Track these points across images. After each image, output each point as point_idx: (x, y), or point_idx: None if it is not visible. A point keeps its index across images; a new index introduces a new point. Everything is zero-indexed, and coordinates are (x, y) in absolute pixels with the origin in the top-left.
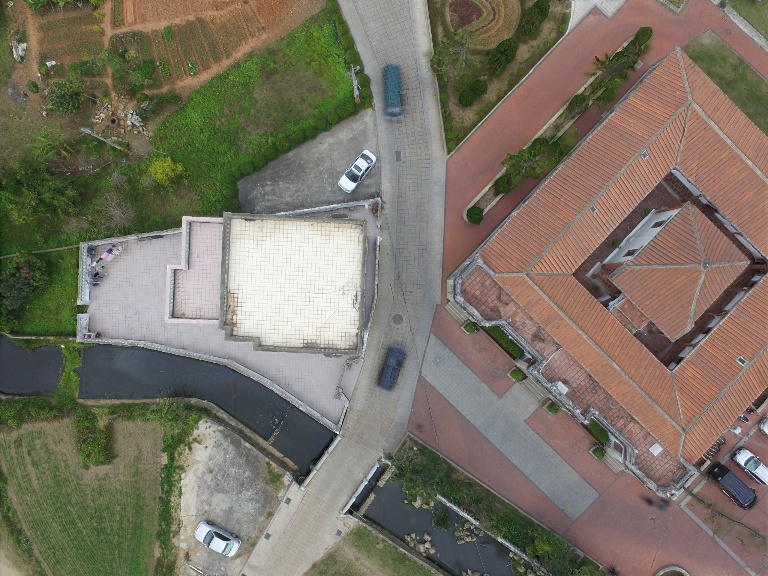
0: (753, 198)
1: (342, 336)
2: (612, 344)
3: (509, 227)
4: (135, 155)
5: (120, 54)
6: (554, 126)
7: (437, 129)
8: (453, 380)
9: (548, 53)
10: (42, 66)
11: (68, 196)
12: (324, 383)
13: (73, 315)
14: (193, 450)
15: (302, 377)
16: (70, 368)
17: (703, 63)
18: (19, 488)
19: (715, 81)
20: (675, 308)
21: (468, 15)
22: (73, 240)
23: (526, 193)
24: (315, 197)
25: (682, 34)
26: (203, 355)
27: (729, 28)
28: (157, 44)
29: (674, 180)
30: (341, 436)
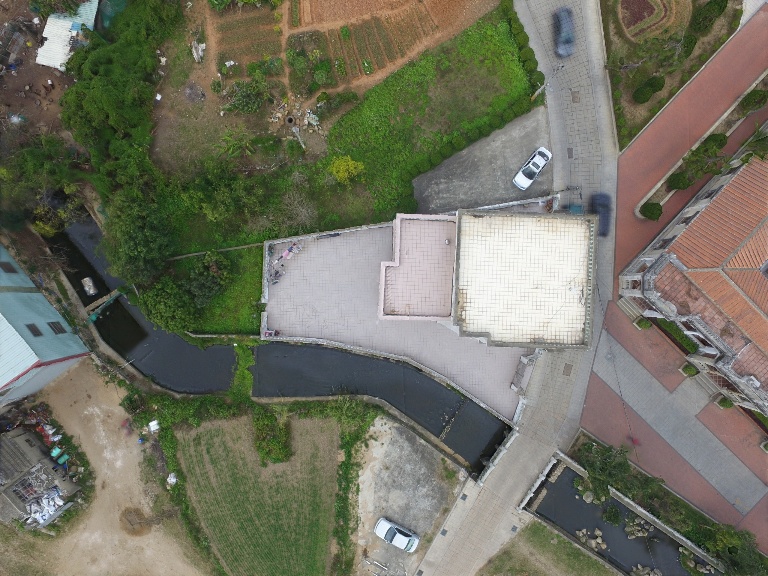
0: None
1: (568, 331)
2: None
3: (698, 222)
4: (311, 154)
5: (298, 54)
6: (726, 122)
7: (608, 126)
8: (625, 376)
9: (719, 50)
10: (221, 66)
11: (256, 195)
12: (498, 379)
13: (252, 313)
14: (370, 447)
15: (476, 374)
16: (244, 366)
17: None
18: (198, 486)
19: None
20: None
21: (640, 12)
22: (252, 239)
23: (697, 189)
24: (488, 194)
25: None
26: (382, 352)
27: None
28: (333, 43)
29: None
30: None
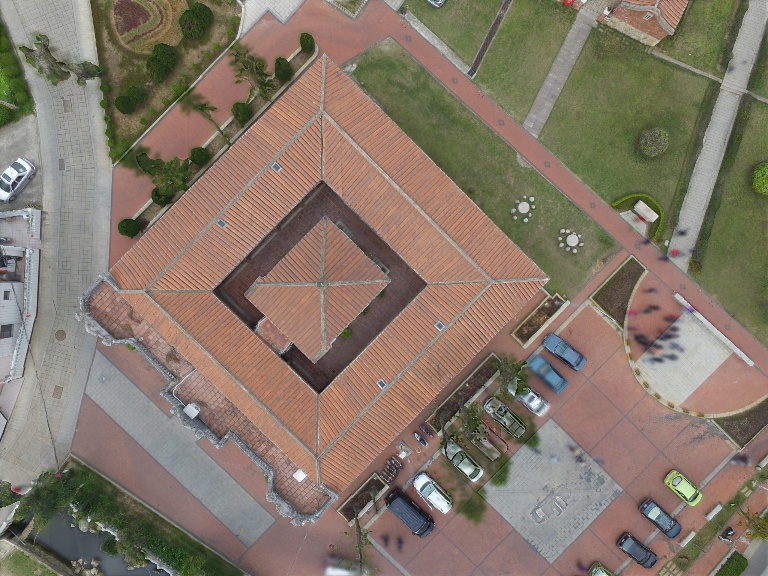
0: (397, 213)
1: None
2: (246, 365)
3: (143, 241)
4: None
5: None
6: (223, 135)
7: (103, 137)
8: (120, 399)
9: (217, 59)
10: None
11: None
12: None
13: None
14: None
15: None
16: None
17: (383, 71)
18: None
19: (396, 90)
20: (308, 328)
21: (134, 18)
22: None
23: None
24: None
25: (360, 41)
26: None
27: (409, 35)
28: None
29: None
30: None
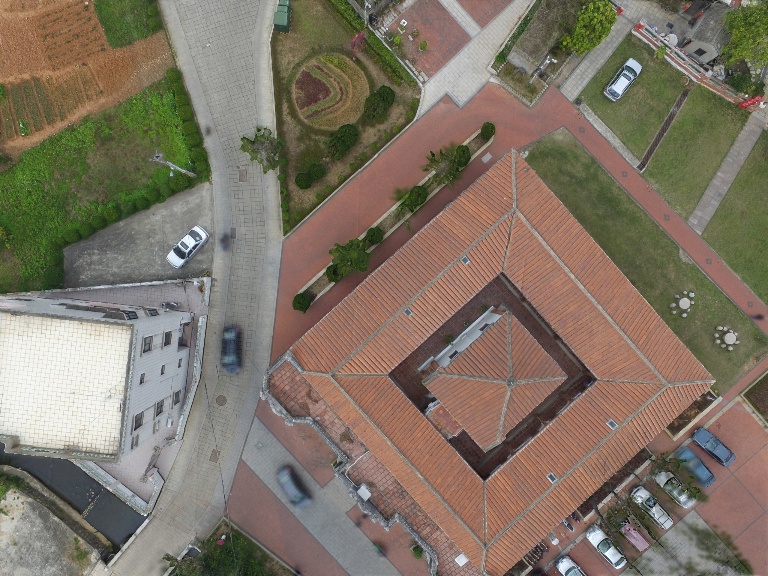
0: (577, 311)
1: (106, 440)
2: (420, 451)
3: (325, 322)
4: None
5: None
6: (395, 214)
7: (275, 208)
8: (275, 466)
9: (394, 139)
10: None
11: None
12: (140, 461)
13: None
14: None
15: None
16: None
17: (554, 160)
18: None
19: (565, 179)
20: (485, 420)
21: (314, 94)
22: None
23: (362, 280)
24: (143, 269)
25: (534, 129)
26: None
27: (583, 126)
28: None
29: None
30: (152, 517)
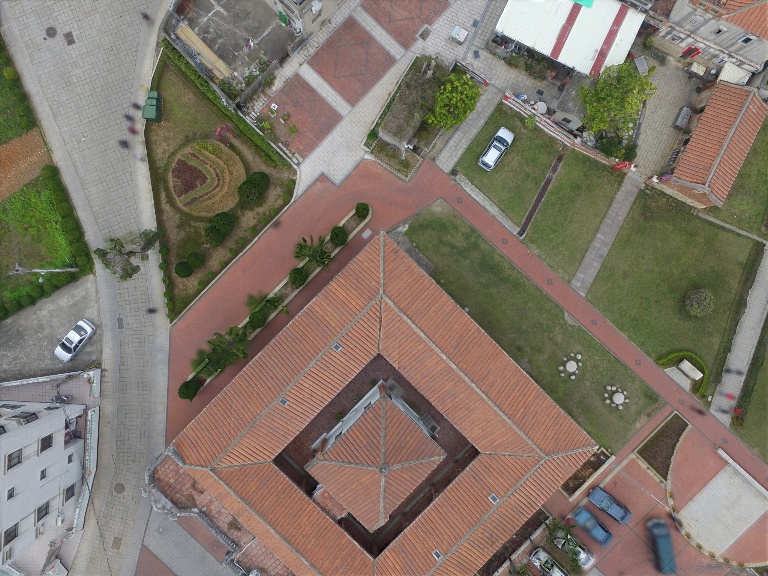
0: (453, 389)
1: None
2: (306, 536)
3: (205, 414)
4: None
5: None
6: (278, 296)
7: (160, 296)
8: (177, 549)
9: (273, 221)
10: None
11: None
12: (43, 553)
13: None
14: None
15: None
16: None
17: (434, 232)
18: None
19: (446, 250)
20: (366, 503)
21: (191, 181)
22: None
23: None
24: (34, 365)
25: (412, 202)
26: None
27: (460, 197)
28: None
29: None
30: None
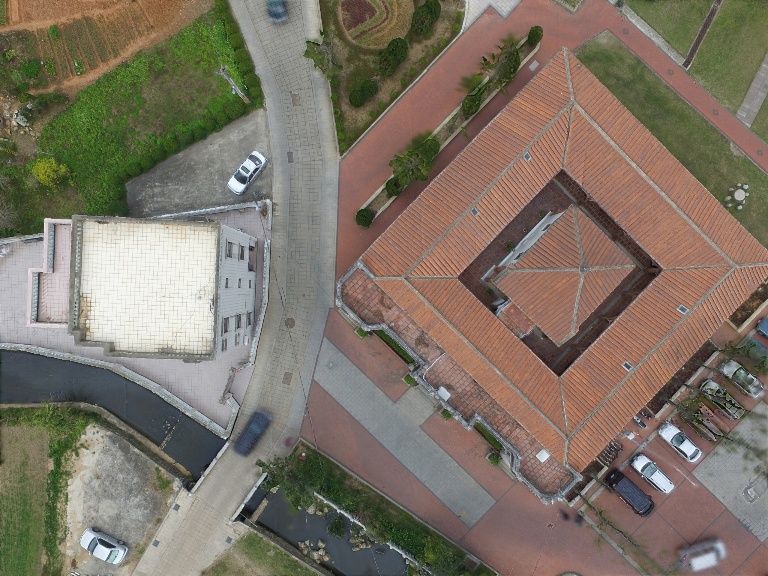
0: (640, 201)
1: (199, 341)
2: (495, 349)
3: (392, 230)
4: (21, 156)
5: (4, 53)
6: (448, 127)
7: (330, 130)
8: (347, 385)
9: (442, 53)
10: None
11: None
12: (214, 388)
13: None
14: (80, 456)
15: (192, 381)
16: None
17: (600, 63)
18: None
19: (613, 82)
20: (558, 312)
21: (361, 14)
22: None
23: None
24: (205, 199)
25: (579, 34)
26: (89, 359)
27: (626, 28)
28: (43, 43)
29: (570, 182)
30: (231, 441)
